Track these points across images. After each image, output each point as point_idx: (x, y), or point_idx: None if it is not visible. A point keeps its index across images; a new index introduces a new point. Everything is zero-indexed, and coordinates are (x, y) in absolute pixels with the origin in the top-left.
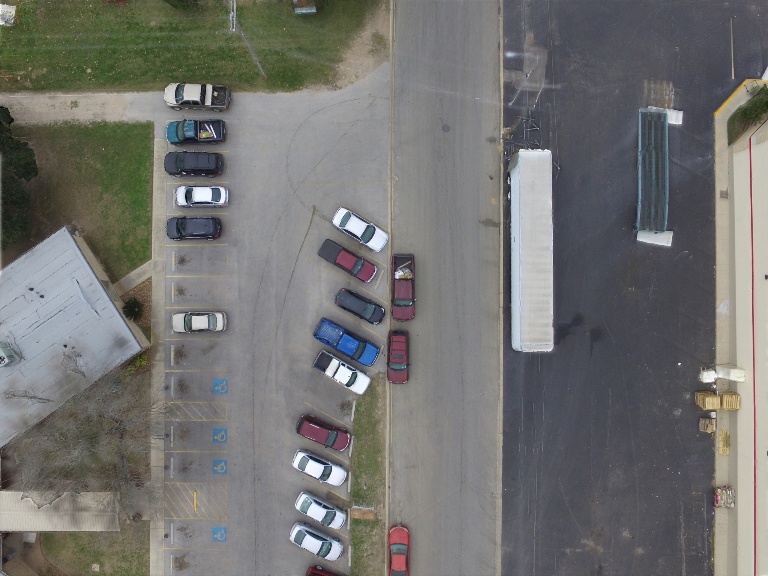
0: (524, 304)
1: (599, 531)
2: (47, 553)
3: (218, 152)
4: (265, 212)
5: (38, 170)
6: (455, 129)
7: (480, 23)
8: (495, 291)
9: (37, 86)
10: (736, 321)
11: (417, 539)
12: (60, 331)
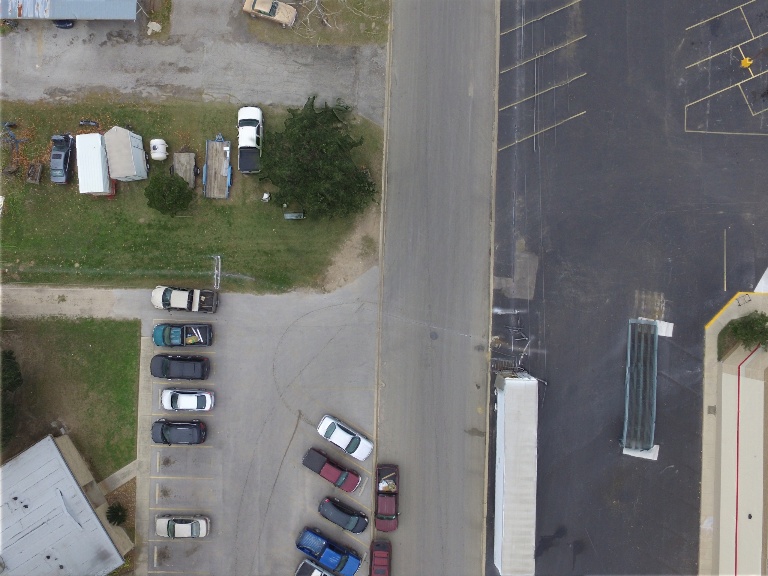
0: (506, 535)
1: None
2: None
3: (205, 353)
4: (251, 415)
5: (24, 364)
6: (443, 337)
7: (471, 229)
8: (479, 501)
9: (24, 279)
10: (720, 541)
11: None
12: (43, 542)
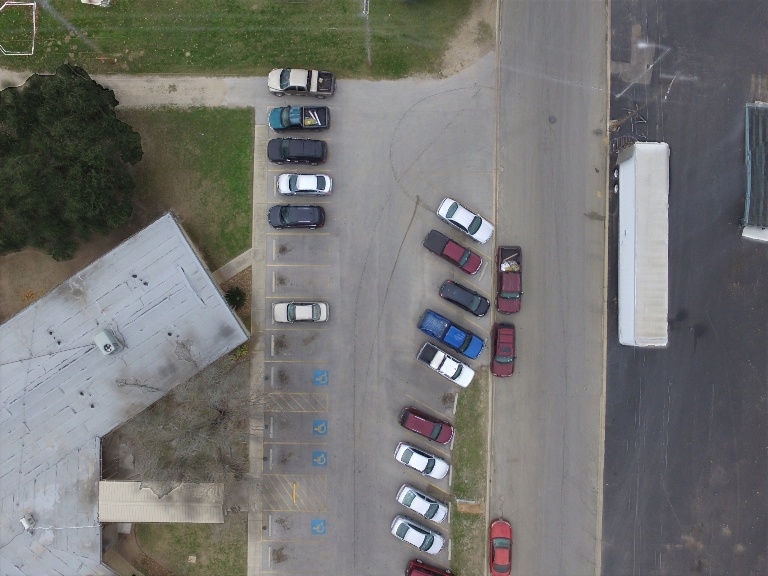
0: (639, 298)
1: (699, 527)
2: (142, 544)
3: (320, 140)
4: (368, 201)
5: None
6: (562, 120)
7: (588, 13)
8: (600, 285)
9: (134, 69)
10: None
11: (518, 533)
12: (164, 319)
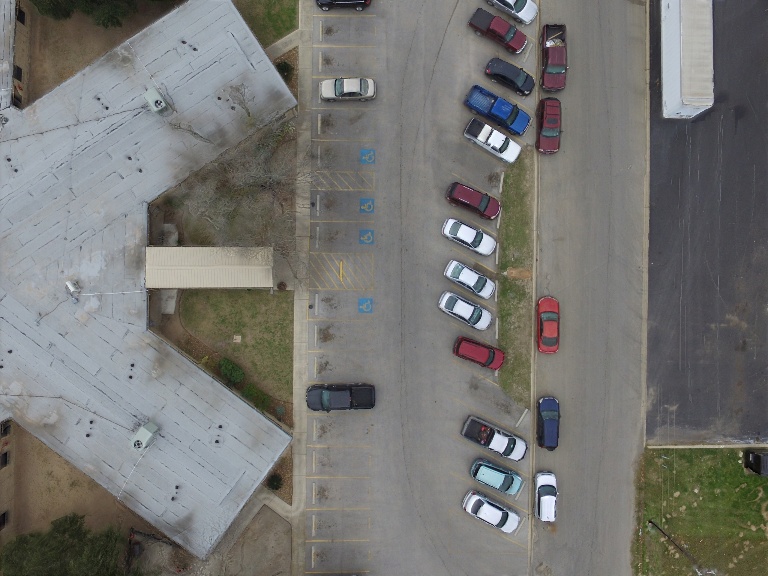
0: (685, 59)
1: (743, 306)
2: (186, 324)
3: None
4: None
5: None
6: None
7: None
8: (642, 67)
9: None
10: None
11: (564, 312)
12: (214, 83)
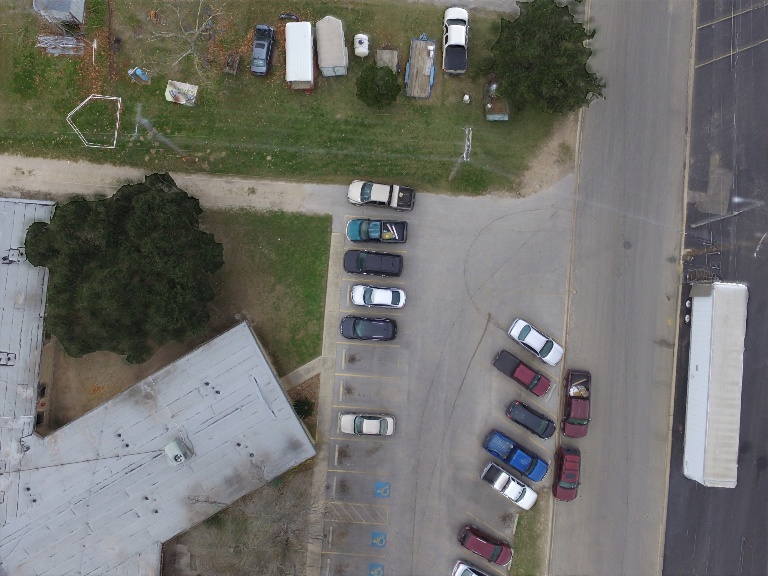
0: (710, 439)
1: None
2: None
3: (396, 252)
4: (440, 316)
5: None
6: (637, 247)
7: (667, 142)
8: (666, 413)
9: (214, 169)
10: None
11: None
12: (234, 429)
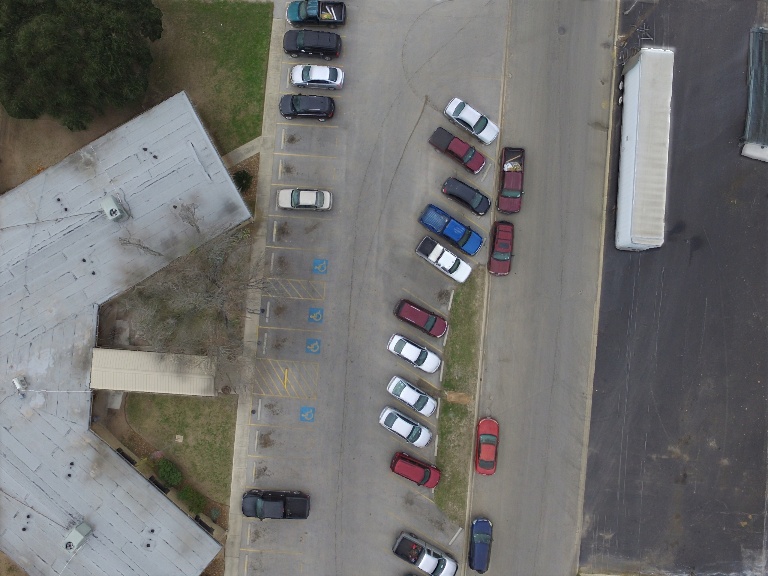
0: (637, 197)
1: (686, 439)
2: (131, 420)
3: None
4: (378, 98)
5: None
6: (571, 32)
7: None
8: (599, 193)
9: None
10: None
11: (505, 433)
12: (171, 192)
